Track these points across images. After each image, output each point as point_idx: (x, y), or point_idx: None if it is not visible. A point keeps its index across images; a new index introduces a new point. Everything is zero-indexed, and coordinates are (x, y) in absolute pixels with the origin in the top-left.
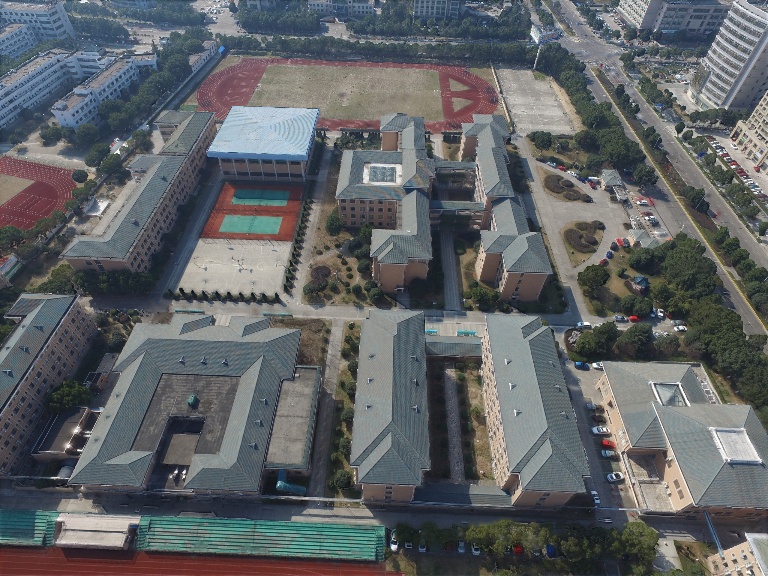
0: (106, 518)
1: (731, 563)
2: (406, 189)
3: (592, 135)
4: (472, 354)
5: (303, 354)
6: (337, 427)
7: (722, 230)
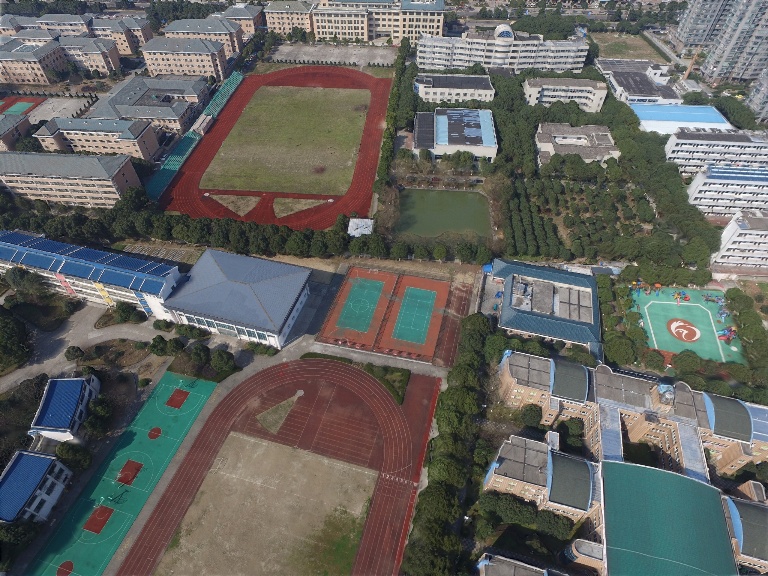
0: (198, 120)
1: (271, 25)
2: (55, 39)
3: (51, 8)
4: None
5: None
6: None
7: (151, 2)
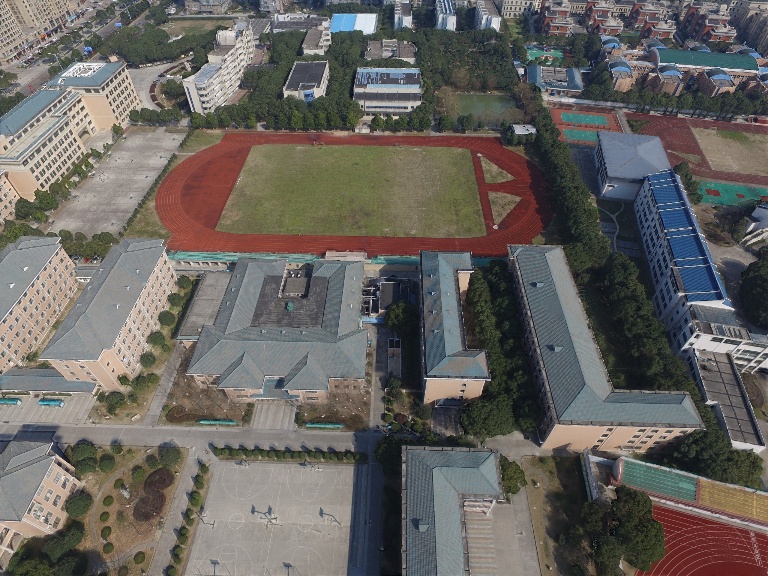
0: None
1: None
2: None
3: None
4: (21, 369)
5: (191, 352)
6: (181, 314)
7: None
